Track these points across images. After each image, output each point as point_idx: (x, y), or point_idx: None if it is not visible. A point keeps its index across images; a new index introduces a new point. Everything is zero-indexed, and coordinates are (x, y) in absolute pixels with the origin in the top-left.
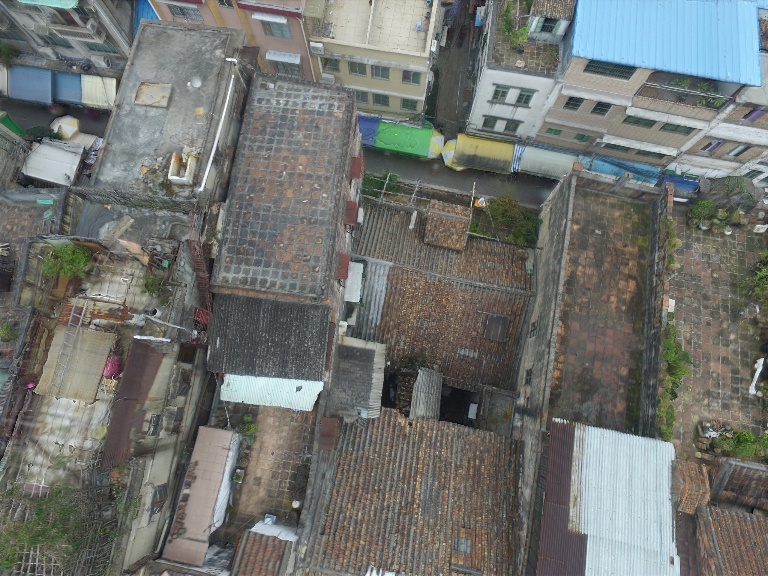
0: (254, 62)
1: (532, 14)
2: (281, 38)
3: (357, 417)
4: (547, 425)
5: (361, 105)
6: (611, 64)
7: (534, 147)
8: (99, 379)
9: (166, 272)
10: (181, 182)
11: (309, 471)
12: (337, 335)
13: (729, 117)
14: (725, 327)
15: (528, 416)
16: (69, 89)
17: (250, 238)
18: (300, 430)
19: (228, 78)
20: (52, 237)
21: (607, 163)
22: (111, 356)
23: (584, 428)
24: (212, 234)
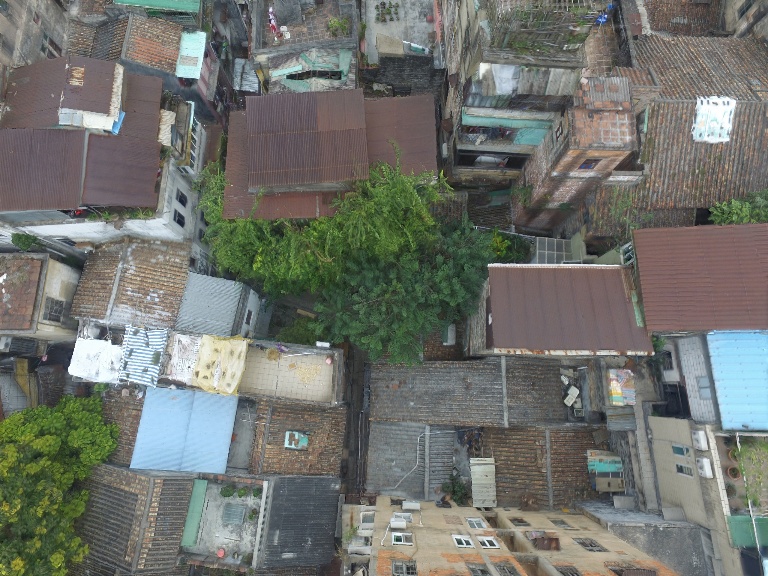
0: None
1: None
2: None
3: None
4: None
5: None
6: None
7: None
8: None
9: None
10: None
11: (628, 52)
12: None
13: None
14: None
15: (762, 18)
16: None
17: None
18: (603, 40)
19: None
20: None
21: None
22: None
23: None
24: None
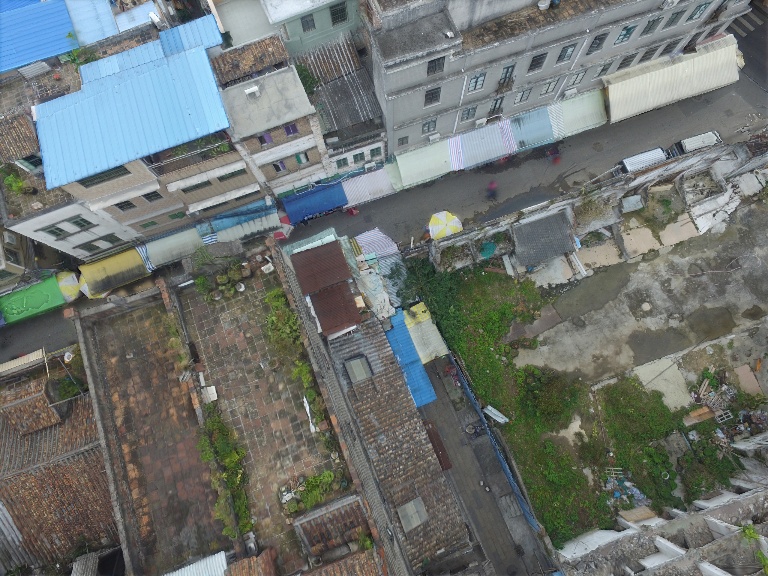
0: None
1: (2, 164)
2: None
3: None
4: None
5: None
6: (93, 175)
7: (151, 242)
8: None
9: None
10: None
11: None
12: None
13: (250, 150)
14: (271, 381)
15: None
16: None
17: None
18: None
19: None
20: None
21: (224, 219)
22: None
23: None
24: None
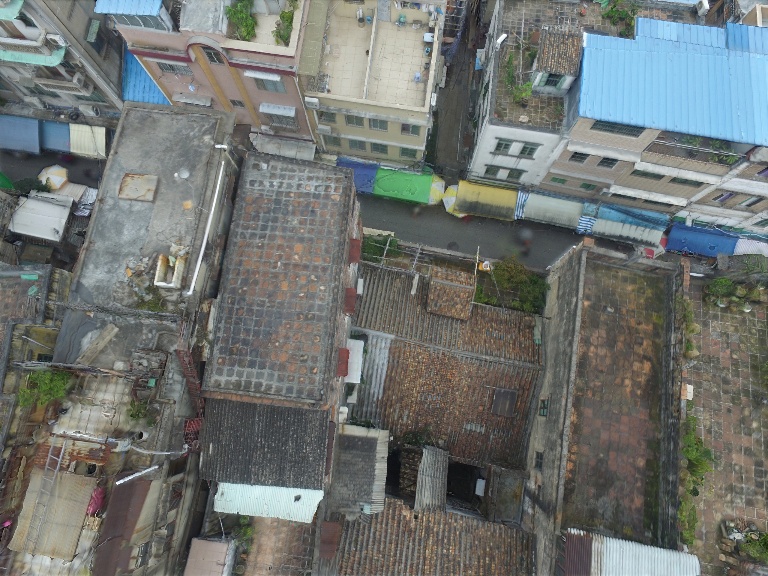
0: (246, 142)
1: (536, 70)
2: (275, 92)
3: (360, 514)
4: (561, 523)
5: (359, 152)
6: (619, 124)
7: (538, 194)
8: (79, 532)
9: (153, 389)
10: (168, 287)
11: None
12: (337, 424)
13: (742, 173)
14: (747, 414)
15: (540, 508)
16: (57, 138)
17: (243, 336)
18: (300, 531)
19: (218, 166)
20: (28, 364)
21: (614, 210)
22: (92, 504)
23: (602, 540)
24: (203, 335)
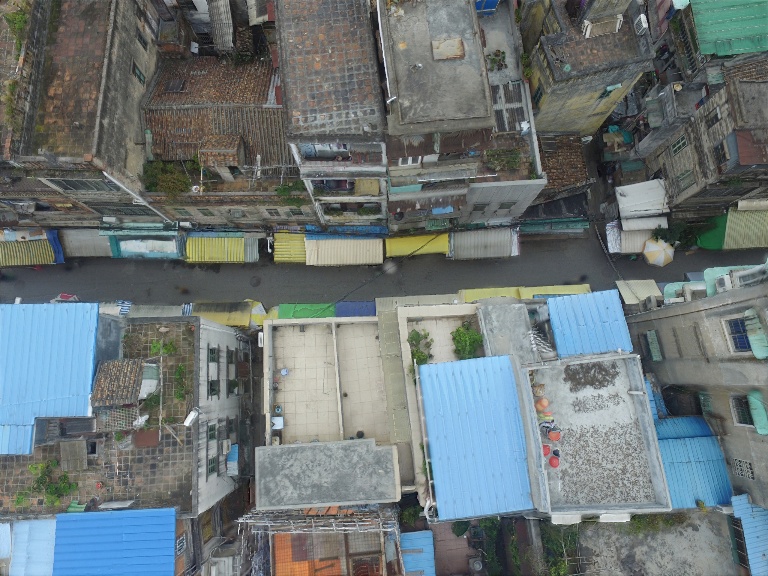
0: (387, 139)
1: (145, 359)
2: None
3: None
4: None
5: None
6: None
7: None
8: None
9: None
10: None
11: None
12: None
13: None
14: None
15: (137, 2)
16: None
17: None
18: None
19: None
20: None
21: None
22: None
23: None
24: None
